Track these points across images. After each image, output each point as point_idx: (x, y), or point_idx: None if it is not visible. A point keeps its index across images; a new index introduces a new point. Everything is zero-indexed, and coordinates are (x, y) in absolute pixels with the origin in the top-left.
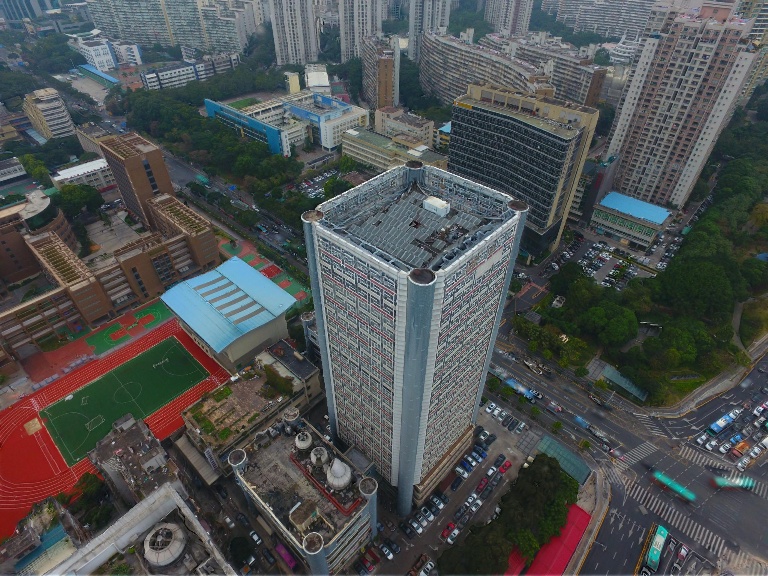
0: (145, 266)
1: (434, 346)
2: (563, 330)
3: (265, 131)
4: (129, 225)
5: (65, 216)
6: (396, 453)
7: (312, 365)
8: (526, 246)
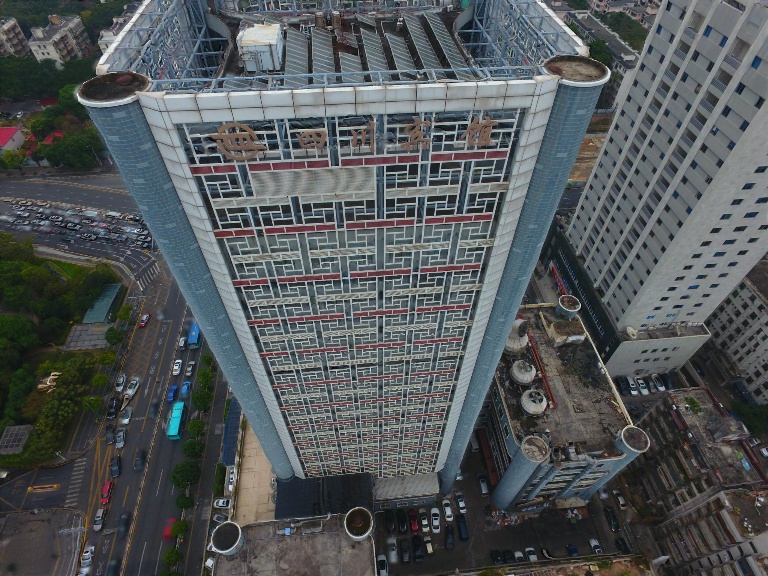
0: None
1: None
2: (29, 390)
3: None
4: None
5: None
6: None
7: None
8: None
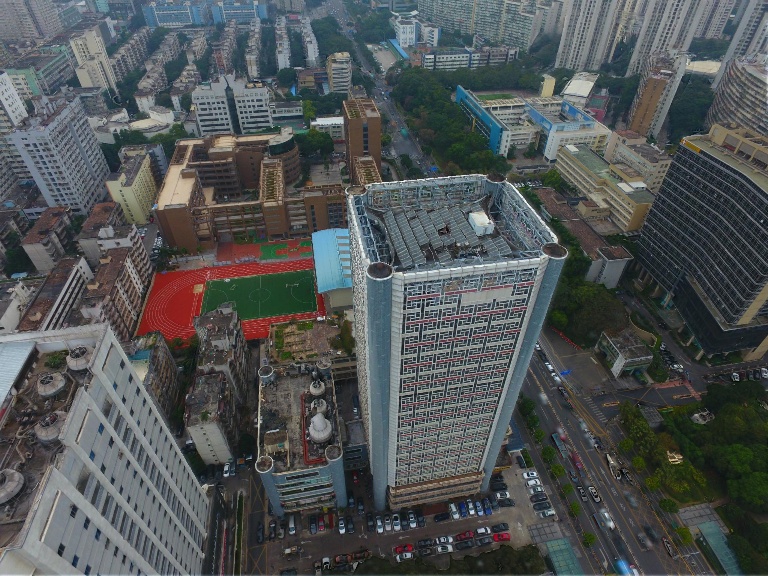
0: (321, 207)
1: (397, 349)
2: (682, 449)
3: (491, 126)
4: (341, 174)
5: (303, 153)
6: (371, 441)
7: None
8: (701, 336)
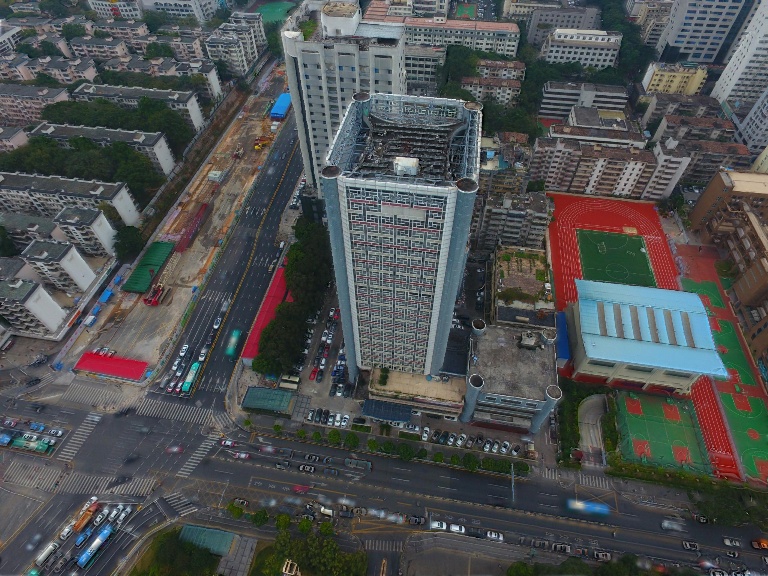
0: None
1: None
2: None
3: None
4: None
5: None
6: None
7: (505, 320)
8: None
